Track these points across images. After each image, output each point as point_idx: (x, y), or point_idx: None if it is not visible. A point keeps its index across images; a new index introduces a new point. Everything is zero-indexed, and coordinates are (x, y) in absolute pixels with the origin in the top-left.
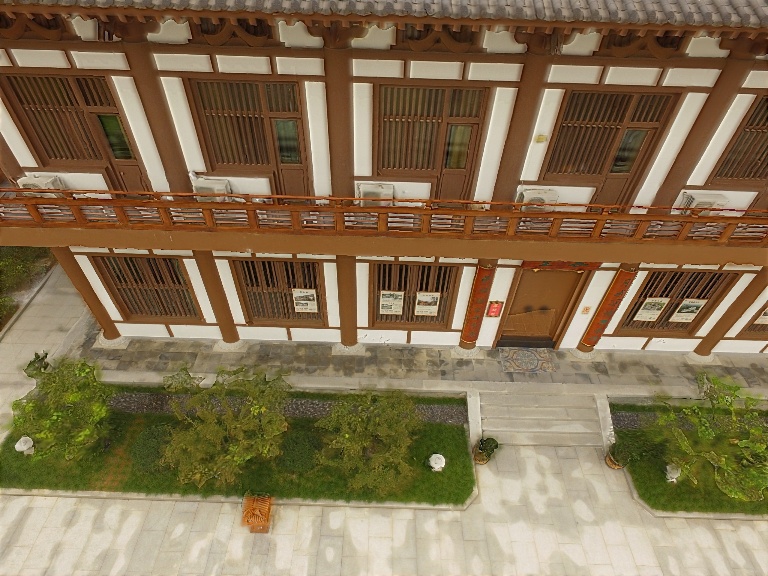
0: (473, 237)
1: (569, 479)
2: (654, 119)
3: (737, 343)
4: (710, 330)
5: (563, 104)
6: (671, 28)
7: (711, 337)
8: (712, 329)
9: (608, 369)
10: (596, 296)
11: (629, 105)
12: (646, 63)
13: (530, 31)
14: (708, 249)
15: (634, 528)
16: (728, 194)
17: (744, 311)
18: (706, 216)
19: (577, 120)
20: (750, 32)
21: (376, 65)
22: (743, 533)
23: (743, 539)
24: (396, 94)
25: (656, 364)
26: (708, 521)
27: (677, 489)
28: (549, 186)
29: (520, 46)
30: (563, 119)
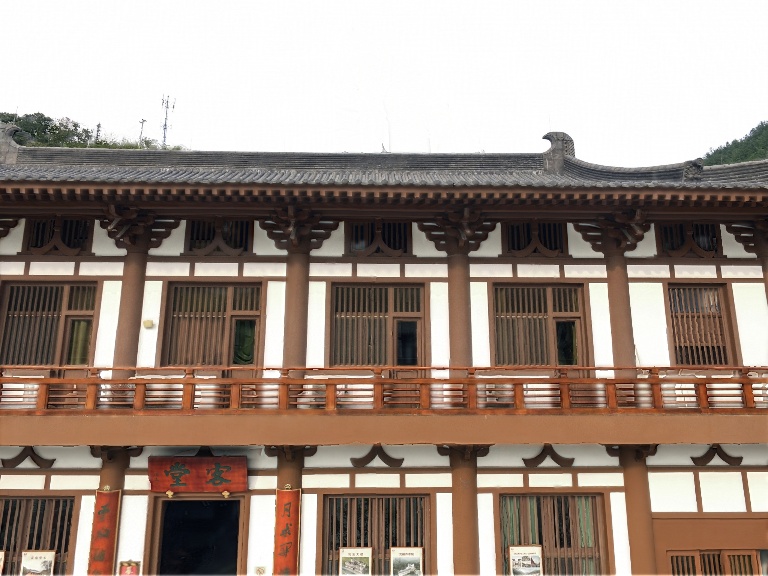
0: (46, 413)
1: None
2: (253, 308)
3: None
4: None
5: (163, 293)
6: (150, 187)
7: None
8: None
9: None
10: (265, 544)
11: (226, 296)
12: (223, 260)
13: (50, 192)
14: (317, 419)
15: None
16: None
17: (477, 565)
18: None
19: (185, 311)
20: (210, 189)
21: (1, 266)
22: None
23: None
24: (22, 292)
25: None
26: None
27: None
28: (168, 376)
29: (121, 251)
30: (171, 310)
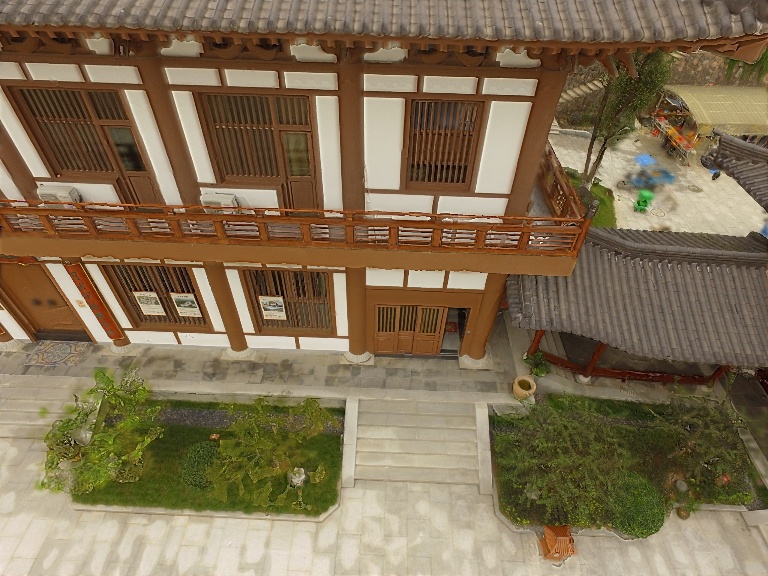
0: None
1: (20, 471)
2: None
3: (265, 339)
4: (224, 325)
5: None
6: None
7: (229, 332)
8: (224, 324)
9: (132, 363)
10: (74, 289)
11: None
12: None
13: None
14: (44, 241)
15: (43, 520)
16: (85, 186)
17: (234, 306)
18: (13, 208)
19: None
20: None
21: None
22: (153, 527)
23: (148, 533)
24: None
25: (186, 359)
26: (127, 515)
27: (109, 483)
28: None
29: None
30: None
